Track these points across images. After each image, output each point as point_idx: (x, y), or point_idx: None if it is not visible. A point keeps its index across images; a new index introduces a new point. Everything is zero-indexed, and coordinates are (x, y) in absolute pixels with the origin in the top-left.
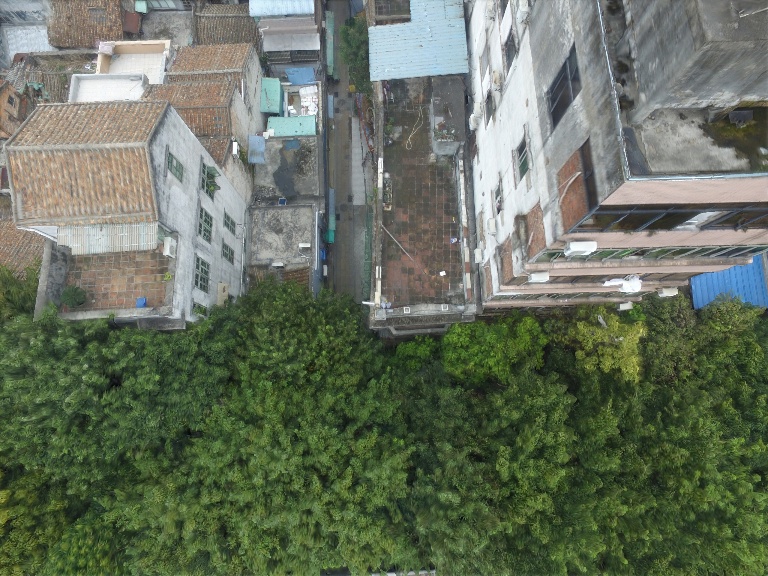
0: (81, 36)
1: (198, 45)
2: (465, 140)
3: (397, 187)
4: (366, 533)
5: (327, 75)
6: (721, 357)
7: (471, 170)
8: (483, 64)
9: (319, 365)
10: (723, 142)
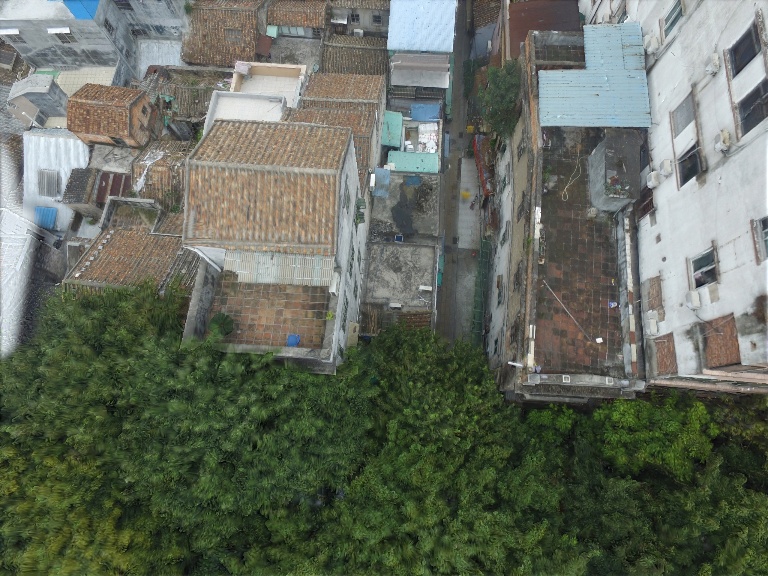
0: (213, 54)
1: (328, 73)
2: (639, 198)
3: (551, 240)
4: None
5: (445, 114)
6: None
7: (635, 230)
8: (676, 120)
9: None
10: None
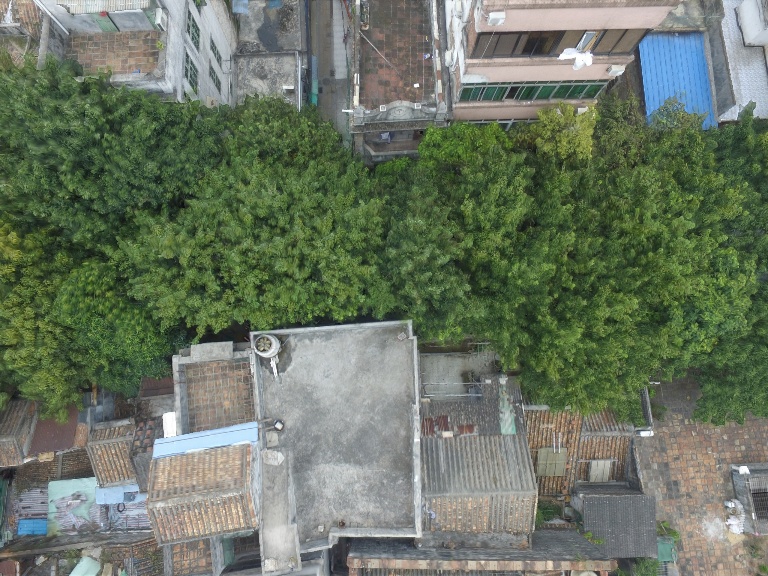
0: None
1: None
2: None
3: (374, 10)
4: (345, 257)
5: None
6: (666, 146)
7: None
8: None
9: (302, 153)
10: None
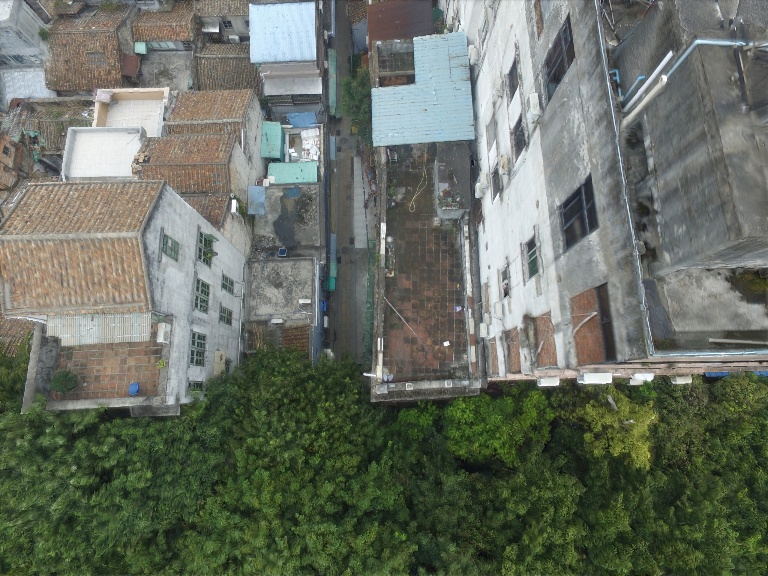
0: (79, 80)
1: None
2: (470, 208)
3: (400, 252)
4: None
5: (329, 115)
6: (735, 440)
7: (476, 235)
8: (490, 134)
9: (318, 446)
10: (752, 297)
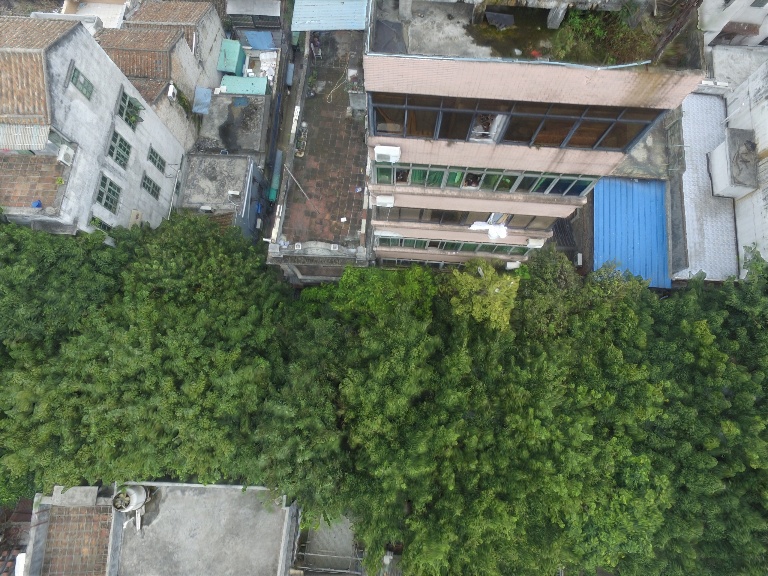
0: None
1: (163, 1)
2: None
3: (312, 136)
4: (203, 431)
5: (291, 45)
6: (594, 318)
7: None
8: None
9: (206, 288)
10: (482, 41)
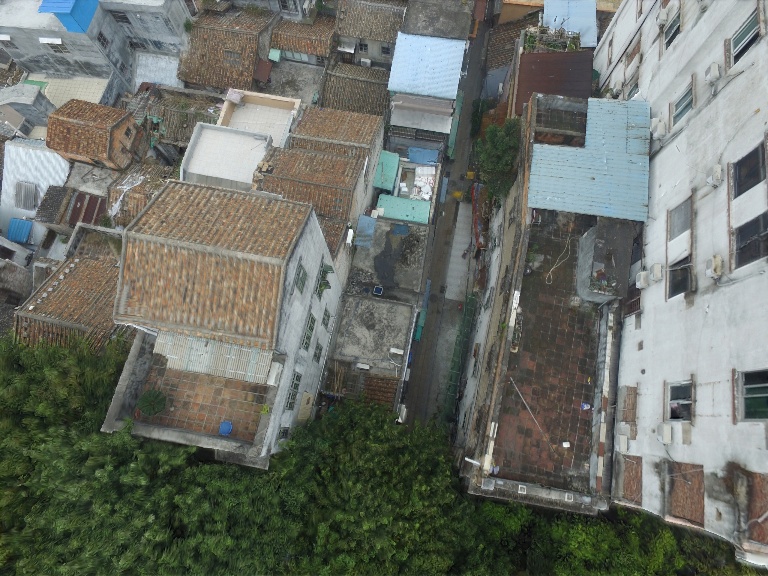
0: (210, 75)
1: None
2: (626, 297)
3: (528, 326)
4: None
5: (446, 156)
6: None
7: (619, 326)
8: (673, 221)
9: None
10: None
